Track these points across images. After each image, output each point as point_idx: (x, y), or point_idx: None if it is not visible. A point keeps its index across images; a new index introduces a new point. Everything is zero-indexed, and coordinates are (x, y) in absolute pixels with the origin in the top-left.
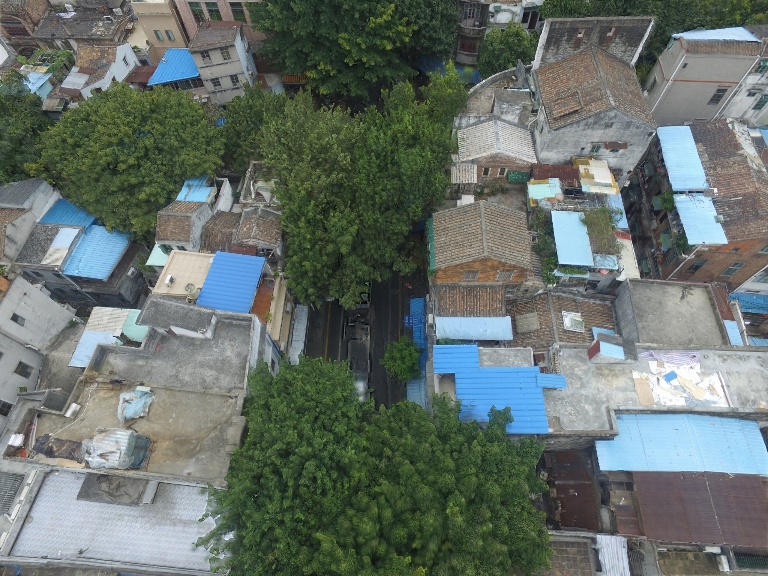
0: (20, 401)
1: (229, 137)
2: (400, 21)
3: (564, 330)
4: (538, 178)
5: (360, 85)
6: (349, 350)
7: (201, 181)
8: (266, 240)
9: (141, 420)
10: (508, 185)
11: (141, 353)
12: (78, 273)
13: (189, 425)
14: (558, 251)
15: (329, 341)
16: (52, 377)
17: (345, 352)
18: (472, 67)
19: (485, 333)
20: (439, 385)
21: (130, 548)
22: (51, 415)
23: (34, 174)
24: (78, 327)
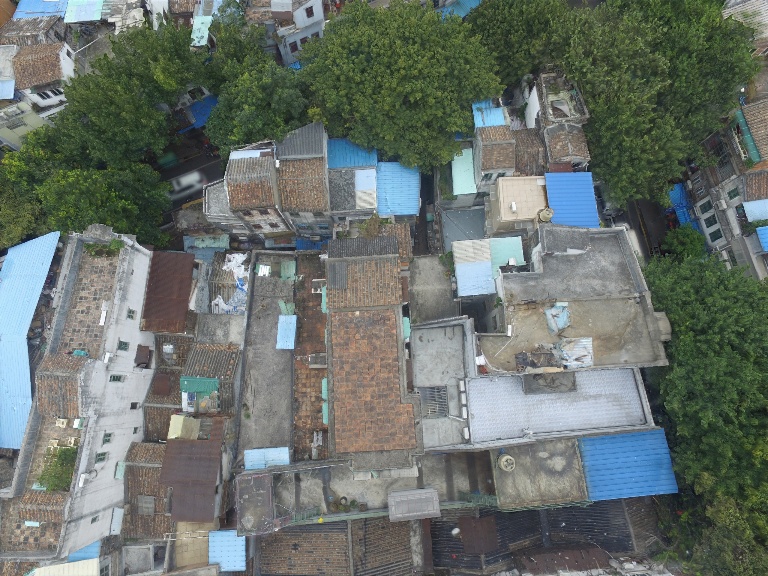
0: (411, 331)
1: (499, 50)
2: None
3: None
4: None
5: None
6: None
7: (487, 103)
8: (581, 155)
9: (567, 328)
10: (762, 62)
11: (533, 275)
12: (391, 212)
13: (607, 326)
14: None
15: None
16: (420, 307)
17: None
18: None
19: None
20: (756, 260)
21: (561, 421)
22: (488, 337)
23: (317, 119)
24: (414, 261)
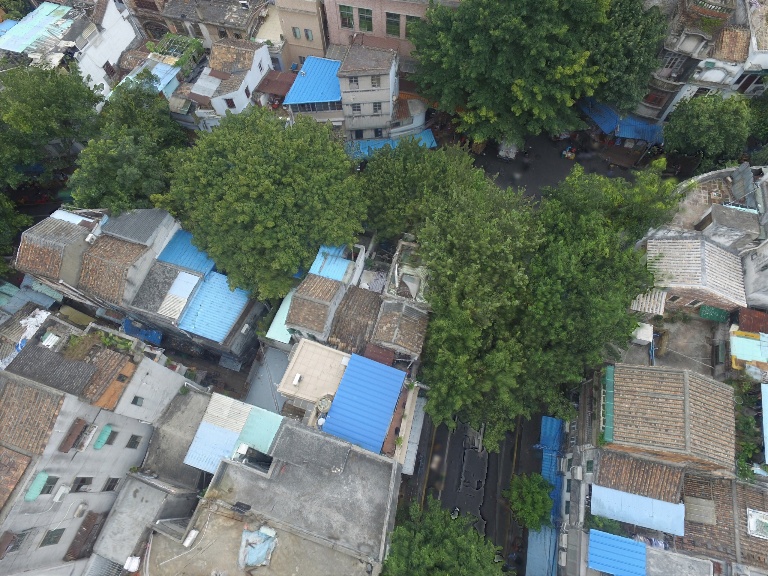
0: (128, 479)
1: (374, 199)
2: (588, 69)
3: (747, 534)
4: (745, 328)
5: (517, 132)
6: (465, 461)
7: (338, 250)
8: (407, 347)
9: (262, 568)
10: (693, 314)
11: None
12: (194, 329)
13: None
14: (766, 445)
15: (437, 432)
16: (161, 453)
17: (454, 450)
18: (648, 120)
19: (651, 520)
20: (586, 571)
21: None
22: None
23: (159, 206)
24: (189, 395)
